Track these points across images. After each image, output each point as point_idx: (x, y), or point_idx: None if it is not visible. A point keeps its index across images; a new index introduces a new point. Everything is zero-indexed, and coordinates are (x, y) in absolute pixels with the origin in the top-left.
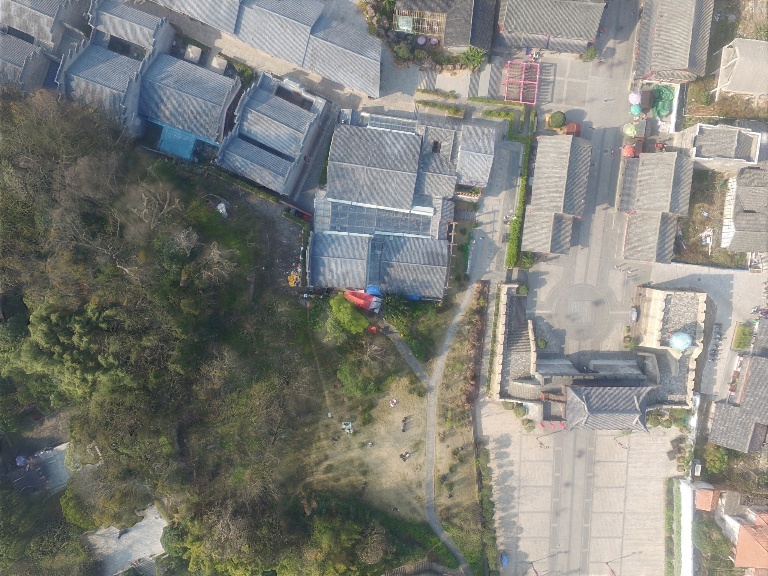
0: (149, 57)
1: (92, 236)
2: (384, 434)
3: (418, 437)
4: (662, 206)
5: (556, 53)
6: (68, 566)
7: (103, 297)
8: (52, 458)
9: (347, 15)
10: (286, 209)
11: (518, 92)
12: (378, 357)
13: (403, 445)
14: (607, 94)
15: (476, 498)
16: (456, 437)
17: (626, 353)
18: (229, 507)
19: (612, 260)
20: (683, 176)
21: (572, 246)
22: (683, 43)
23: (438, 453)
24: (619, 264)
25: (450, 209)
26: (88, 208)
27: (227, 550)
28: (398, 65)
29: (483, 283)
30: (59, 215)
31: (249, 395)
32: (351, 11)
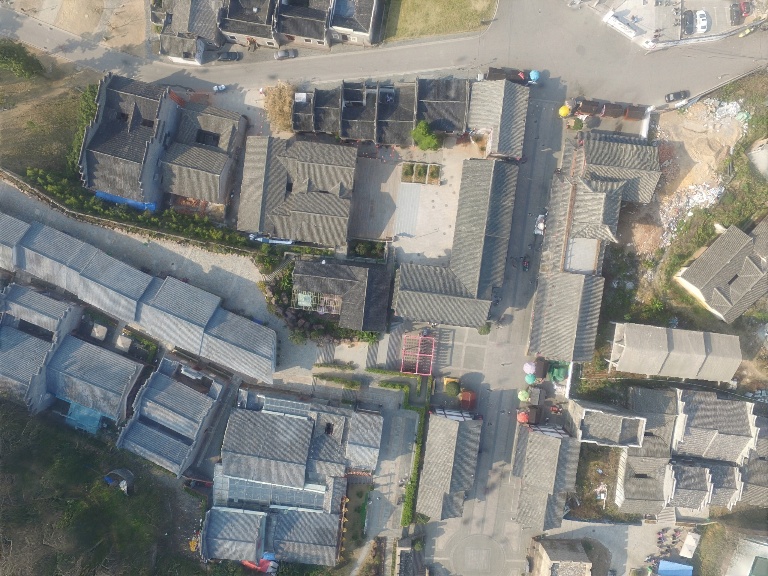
0: (54, 346)
1: None
2: None
3: None
4: (547, 487)
5: None
6: None
7: None
8: None
9: (247, 293)
10: (187, 481)
11: (414, 363)
12: None
13: None
14: (504, 358)
15: None
16: None
17: None
18: None
19: (508, 513)
20: (569, 456)
21: (469, 499)
22: (569, 337)
23: None
24: (515, 516)
25: (342, 485)
26: None
27: None
28: None
29: (379, 542)
30: None
31: None
32: (251, 289)
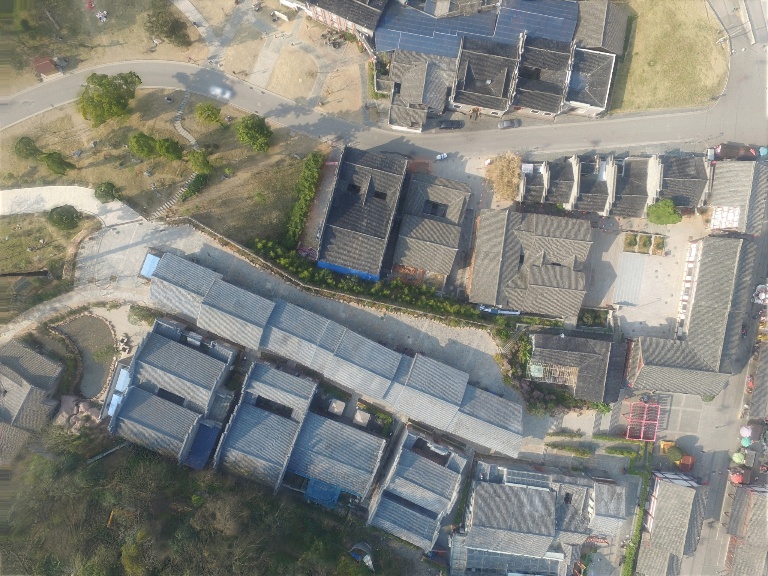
0: (301, 425)
1: None
2: None
3: None
4: None
5: None
6: None
7: None
8: None
9: (483, 366)
10: None
11: (639, 429)
12: None
13: None
14: (718, 421)
15: None
16: None
17: None
18: None
19: (714, 567)
20: None
21: None
22: None
23: None
24: (720, 570)
25: (578, 552)
26: None
27: None
28: (530, 412)
29: None
30: None
31: None
32: (487, 362)
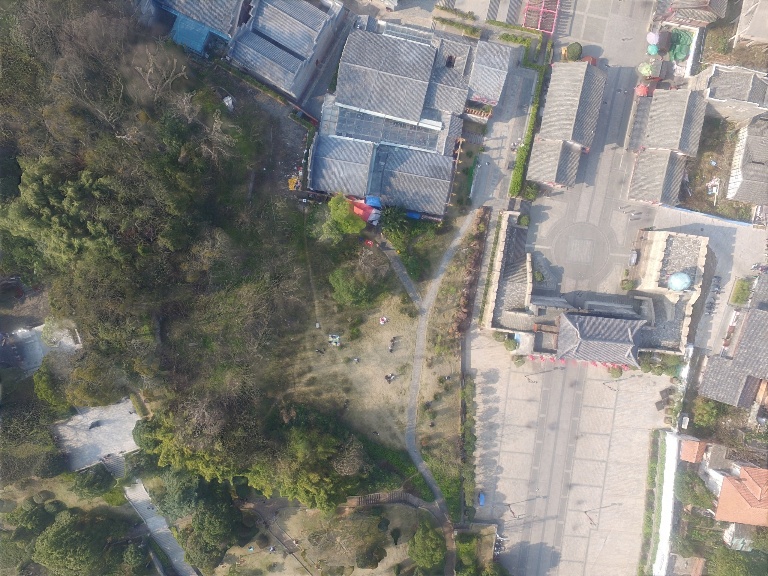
0: None
1: (93, 95)
2: (371, 352)
3: (405, 360)
4: (672, 143)
5: None
6: (35, 456)
7: (98, 164)
8: (30, 338)
9: None
10: (293, 111)
11: (537, 20)
12: (372, 265)
13: (389, 366)
14: (625, 33)
15: (458, 431)
16: (444, 365)
17: (623, 297)
18: (206, 403)
19: (616, 201)
20: (695, 116)
21: (577, 183)
22: None
23: (424, 379)
24: (623, 206)
25: (458, 126)
26: (92, 66)
27: (200, 446)
28: None
29: (485, 208)
30: (62, 64)
31: (237, 295)
32: None
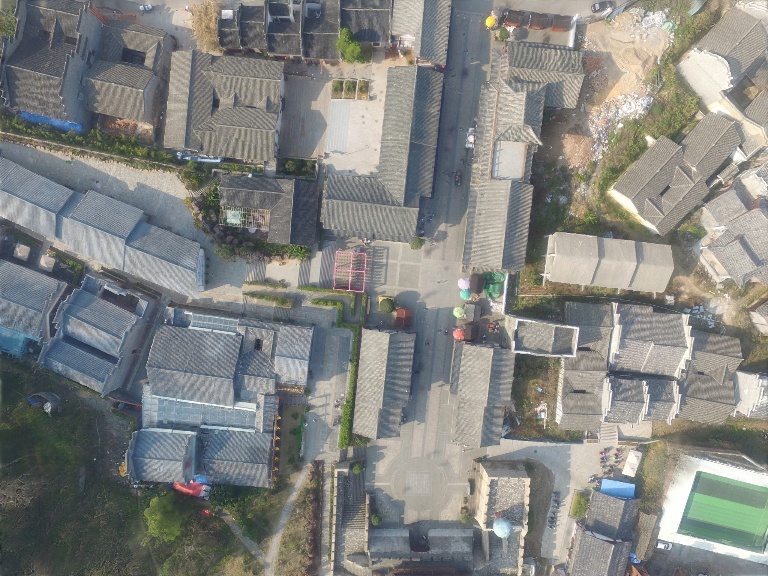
0: None
1: None
2: None
3: None
4: (481, 399)
5: None
6: None
7: None
8: None
9: (174, 210)
10: (115, 403)
11: (347, 280)
12: (199, 553)
13: None
14: (440, 276)
15: None
16: None
17: None
18: None
19: (448, 435)
20: (504, 368)
21: (409, 422)
22: (498, 244)
23: None
24: None
25: (274, 403)
26: None
27: None
28: (225, 259)
29: (315, 465)
30: None
31: None
32: (178, 206)
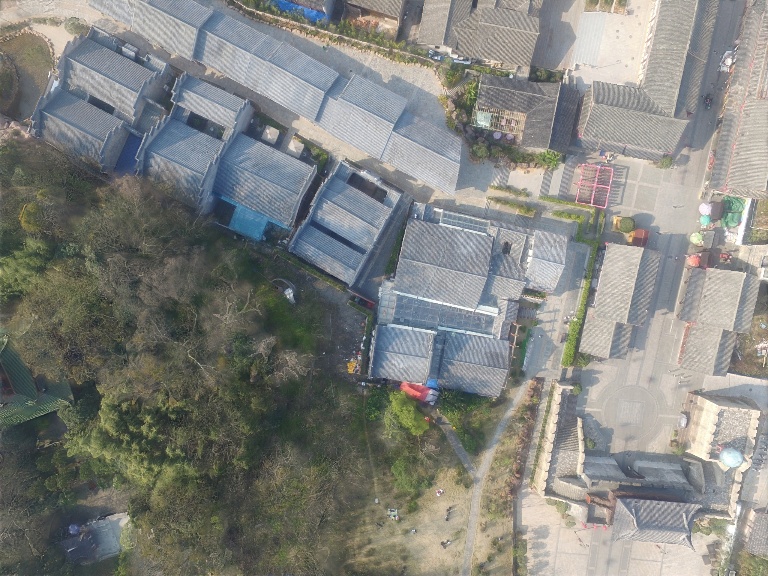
0: (229, 139)
1: (171, 333)
2: (428, 522)
3: (460, 526)
4: (726, 324)
5: (630, 157)
6: None
7: (174, 388)
8: (104, 527)
9: (427, 106)
10: (351, 297)
11: (590, 194)
12: (433, 454)
13: (445, 533)
14: (677, 201)
15: None
16: (497, 527)
17: (671, 456)
18: None
19: (666, 364)
20: (749, 295)
21: (628, 348)
22: (763, 165)
23: (478, 542)
24: (673, 369)
25: (514, 310)
26: (170, 306)
27: None
28: (473, 160)
29: (538, 381)
30: (144, 317)
31: (301, 478)
32: (431, 103)
